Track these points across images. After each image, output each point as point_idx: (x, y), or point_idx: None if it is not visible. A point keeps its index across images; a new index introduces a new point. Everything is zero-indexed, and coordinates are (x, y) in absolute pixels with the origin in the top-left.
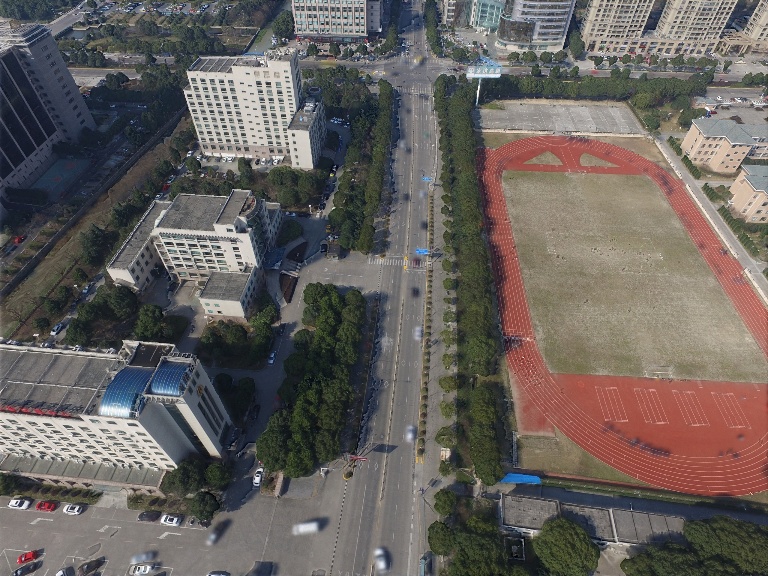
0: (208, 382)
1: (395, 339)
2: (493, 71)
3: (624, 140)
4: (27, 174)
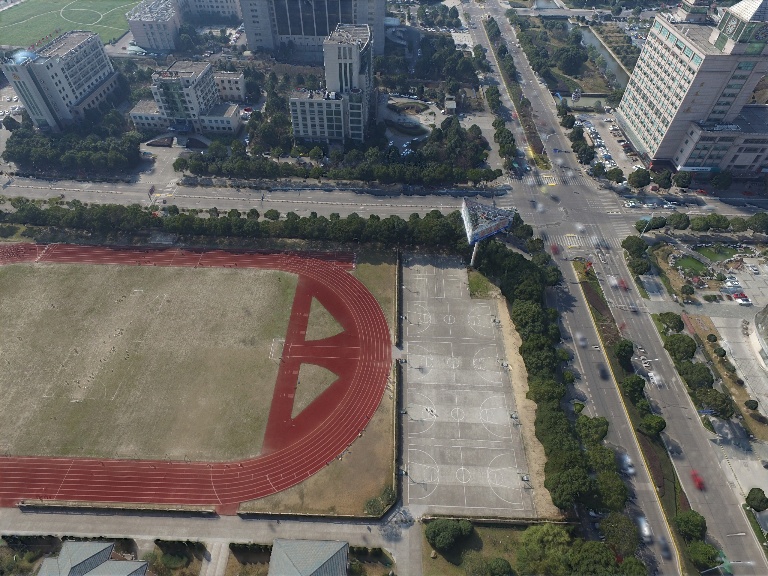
0: (28, 83)
1: (86, 189)
2: (469, 229)
3: (381, 455)
4: (311, 44)
